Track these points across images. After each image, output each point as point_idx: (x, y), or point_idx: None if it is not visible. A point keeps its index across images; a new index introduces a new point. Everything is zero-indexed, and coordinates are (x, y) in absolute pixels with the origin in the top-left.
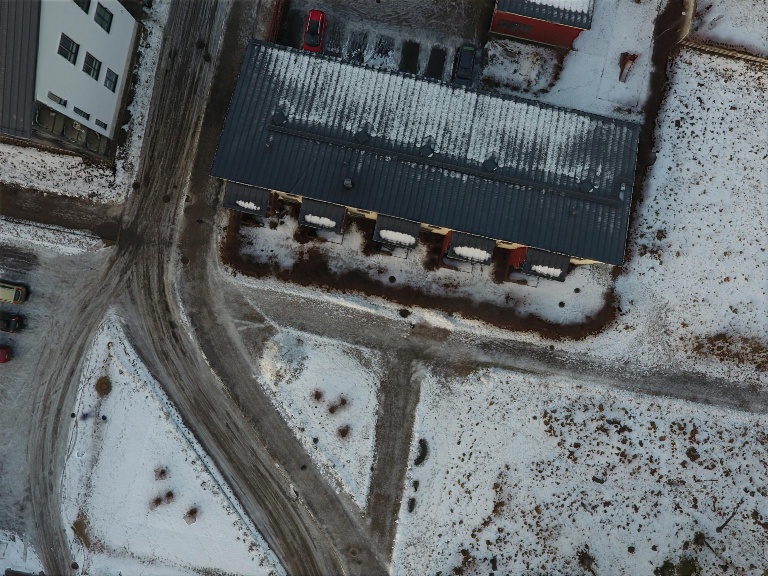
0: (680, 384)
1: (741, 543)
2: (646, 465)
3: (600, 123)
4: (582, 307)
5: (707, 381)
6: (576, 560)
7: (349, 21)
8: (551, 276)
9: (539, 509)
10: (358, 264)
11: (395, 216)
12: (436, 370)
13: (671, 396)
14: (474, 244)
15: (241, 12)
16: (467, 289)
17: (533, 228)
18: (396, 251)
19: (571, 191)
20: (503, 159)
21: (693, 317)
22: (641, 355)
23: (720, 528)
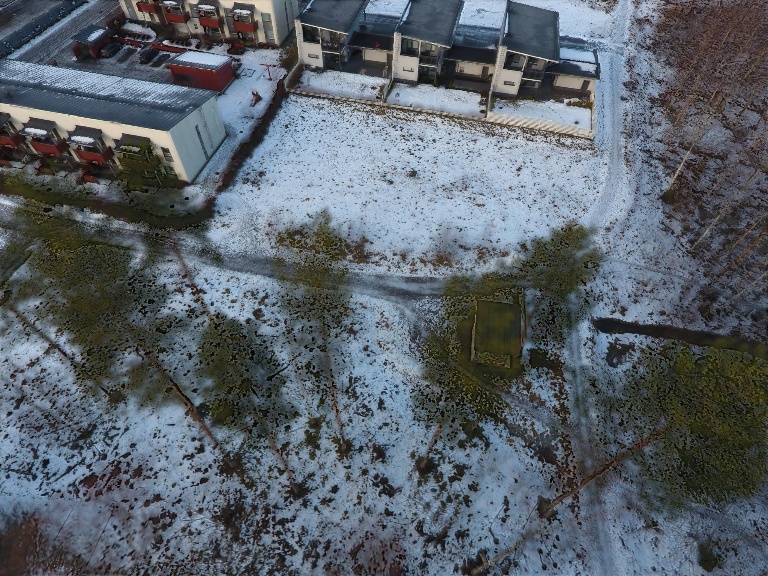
0: (261, 265)
1: (289, 391)
2: (211, 320)
3: (194, 89)
4: (188, 208)
5: (285, 264)
6: (106, 398)
7: None
8: (132, 151)
9: (91, 352)
10: (28, 181)
11: (28, 107)
12: (52, 244)
13: (251, 273)
14: (86, 135)
15: None
16: (102, 195)
17: None
18: (59, 173)
19: (154, 105)
20: (120, 95)
21: (278, 220)
22: (232, 244)
23: (271, 377)
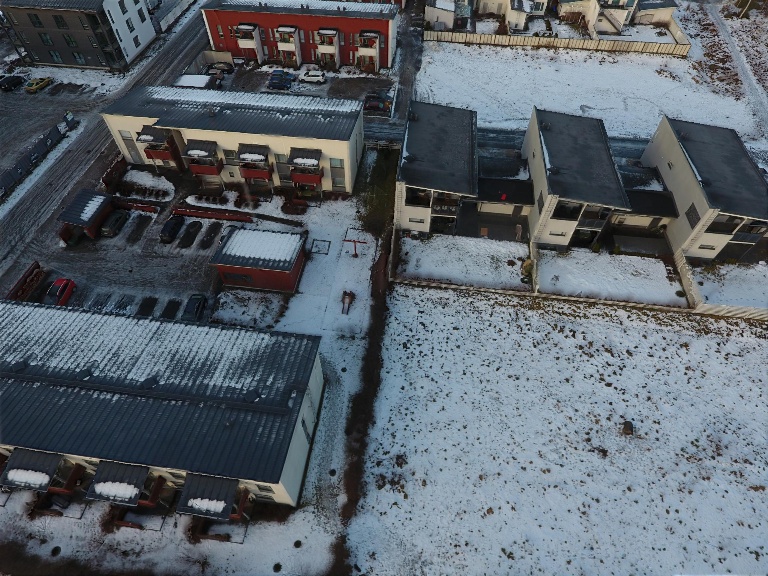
0: None
1: None
2: None
3: (280, 338)
4: (305, 569)
5: None
6: None
7: (98, 286)
8: (212, 512)
9: None
10: (17, 533)
11: (11, 445)
12: None
13: None
14: (121, 477)
15: (1, 287)
16: (152, 556)
17: (177, 446)
18: (70, 509)
19: (232, 402)
20: (167, 376)
21: (458, 571)
22: None
23: None
